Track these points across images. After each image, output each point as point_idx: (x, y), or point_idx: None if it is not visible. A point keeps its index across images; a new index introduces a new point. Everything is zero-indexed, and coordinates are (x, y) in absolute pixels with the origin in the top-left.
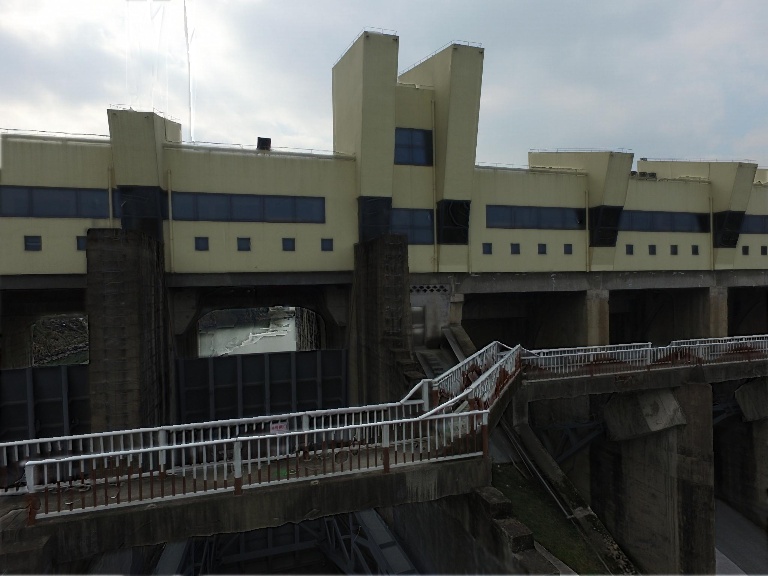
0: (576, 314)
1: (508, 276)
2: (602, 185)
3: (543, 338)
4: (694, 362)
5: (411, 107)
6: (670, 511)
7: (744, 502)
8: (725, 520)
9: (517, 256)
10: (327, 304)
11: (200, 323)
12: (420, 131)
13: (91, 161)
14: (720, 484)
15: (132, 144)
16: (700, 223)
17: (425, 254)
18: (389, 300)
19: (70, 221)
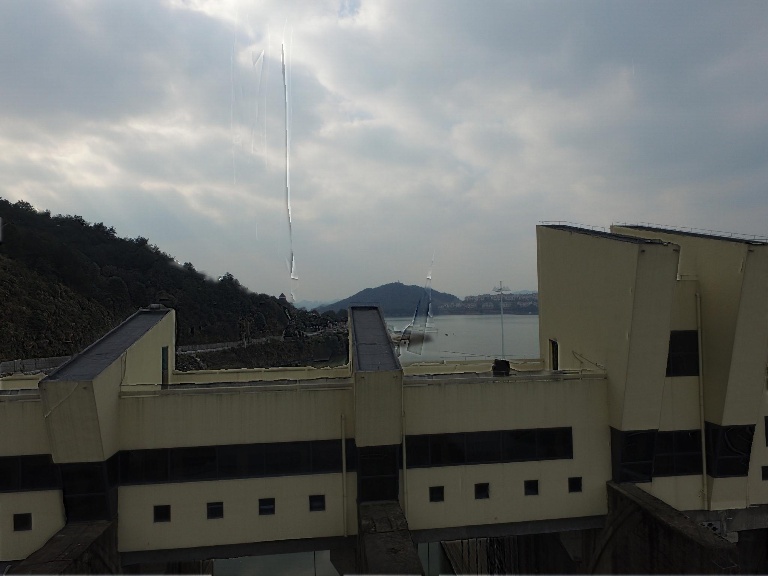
0: None
1: None
2: None
3: None
4: None
5: None
6: None
7: None
8: None
9: None
10: (560, 535)
11: (299, 357)
12: (682, 332)
13: (324, 409)
14: None
15: (377, 404)
16: None
17: (691, 487)
18: None
19: (303, 479)
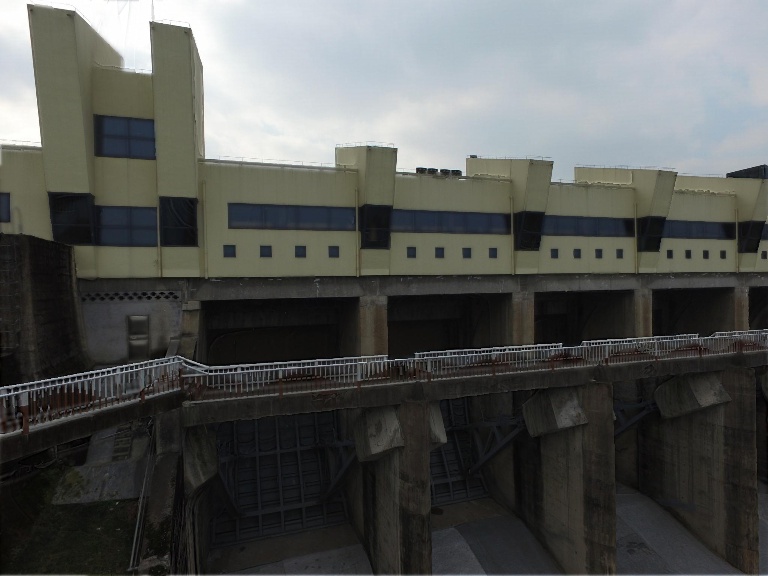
0: (355, 322)
1: (259, 281)
2: (364, 182)
3: (343, 347)
4: (421, 377)
5: (129, 94)
6: (396, 541)
7: (536, 523)
8: (514, 543)
9: (268, 259)
10: None
11: None
12: (140, 120)
13: None
14: (520, 503)
15: None
16: (500, 224)
17: (146, 257)
18: (1, 311)
19: None
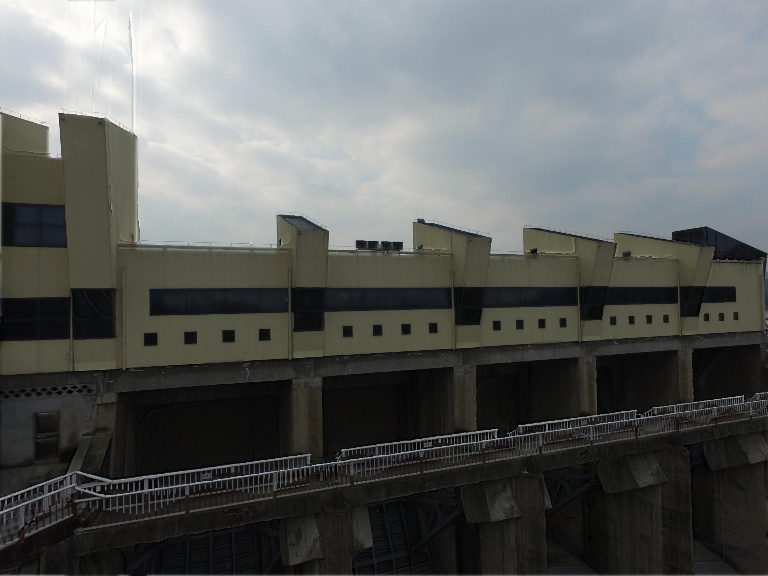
0: (289, 403)
1: (183, 369)
2: (295, 265)
3: (281, 422)
4: (343, 481)
5: (42, 179)
6: None
7: None
8: None
9: (193, 346)
10: None
11: None
12: (55, 207)
13: None
14: None
15: None
16: (441, 298)
17: (57, 350)
18: None
19: None
